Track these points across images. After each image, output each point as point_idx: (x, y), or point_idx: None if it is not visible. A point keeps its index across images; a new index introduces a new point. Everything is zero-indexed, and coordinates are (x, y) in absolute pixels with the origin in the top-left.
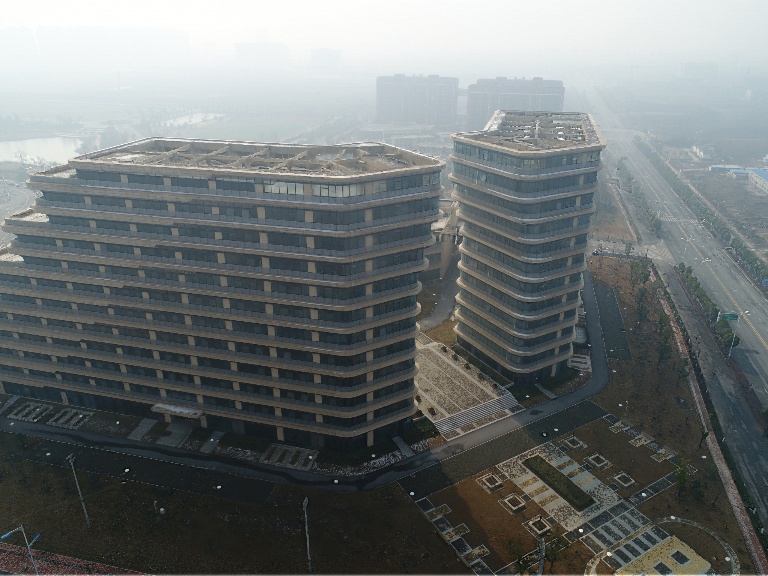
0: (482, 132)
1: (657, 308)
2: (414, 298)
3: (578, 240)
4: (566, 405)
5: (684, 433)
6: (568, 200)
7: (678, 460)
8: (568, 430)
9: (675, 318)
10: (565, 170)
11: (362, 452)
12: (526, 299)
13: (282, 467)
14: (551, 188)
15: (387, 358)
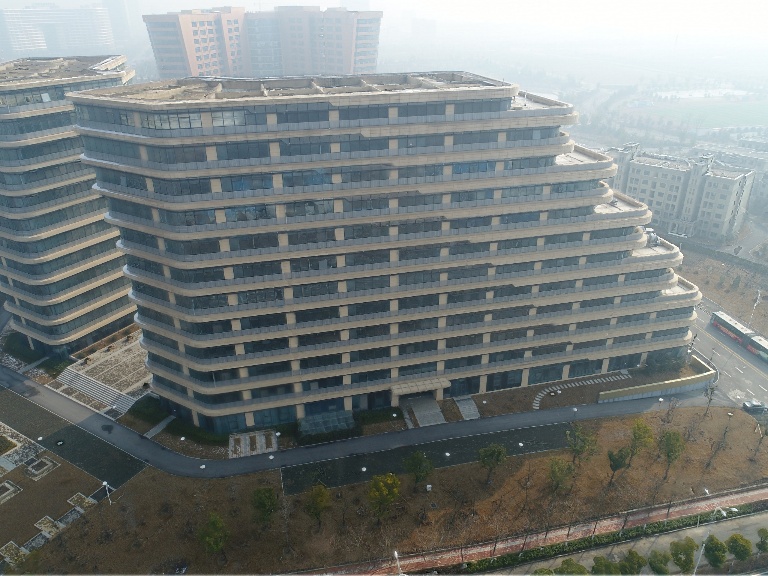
0: (226, 80)
1: (548, 513)
2: (21, 224)
3: (171, 246)
4: (129, 448)
5: (75, 575)
6: (134, 177)
7: (1, 571)
8: (70, 459)
9: (533, 546)
10: (114, 130)
11: (21, 347)
12: (129, 292)
13: (6, 324)
14: (108, 152)
15: (16, 272)
